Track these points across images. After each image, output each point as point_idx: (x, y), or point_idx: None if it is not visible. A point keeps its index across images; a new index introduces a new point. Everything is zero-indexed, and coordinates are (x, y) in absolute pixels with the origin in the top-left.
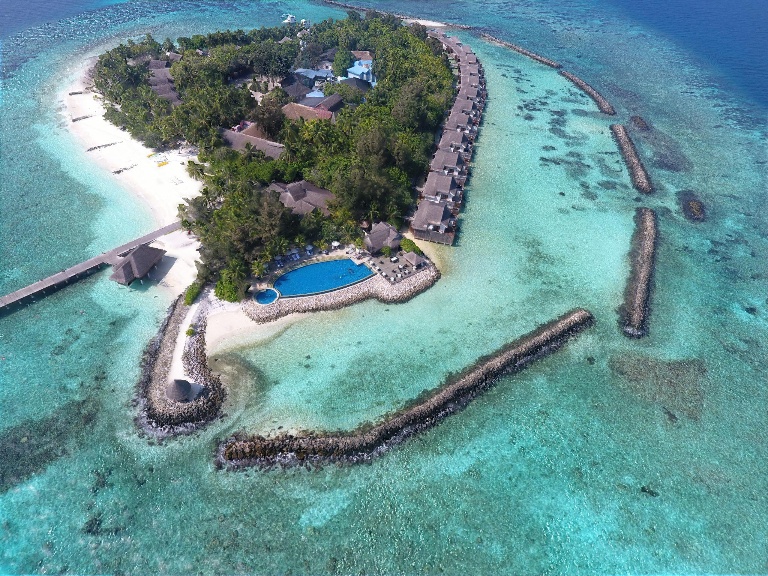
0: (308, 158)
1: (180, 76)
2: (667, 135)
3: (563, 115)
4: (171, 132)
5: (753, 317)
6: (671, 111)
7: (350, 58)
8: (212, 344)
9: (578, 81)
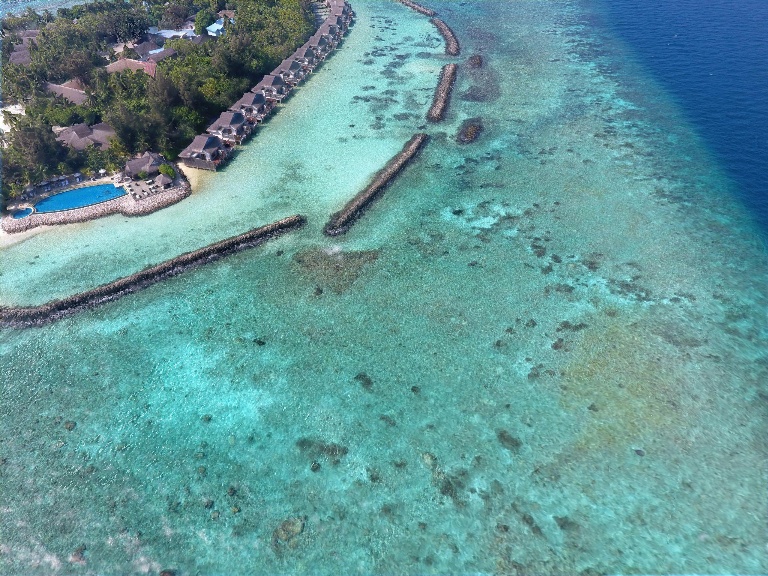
0: (109, 103)
1: (30, 40)
2: (496, 71)
3: (405, 58)
4: (1, 88)
5: (455, 217)
6: (518, 49)
7: (211, 17)
8: None
9: (442, 27)
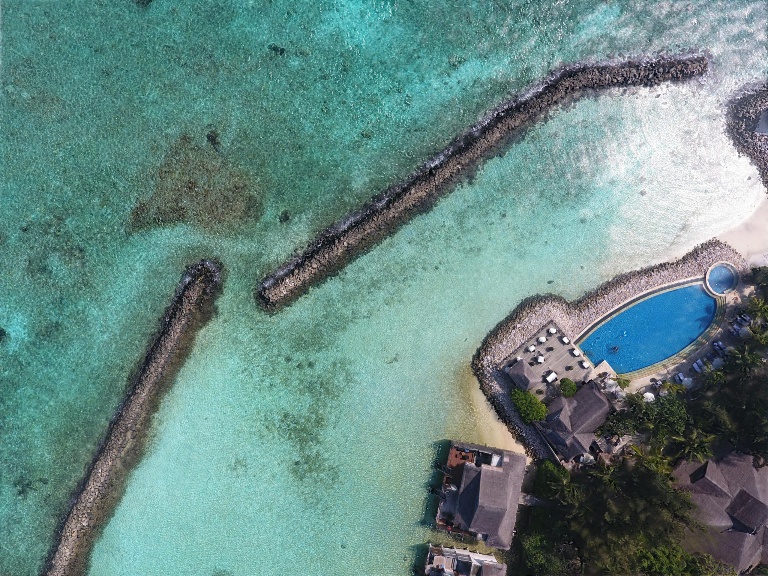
0: None
1: None
2: None
3: None
4: None
5: (1, 322)
6: None
7: None
8: (762, 201)
9: None
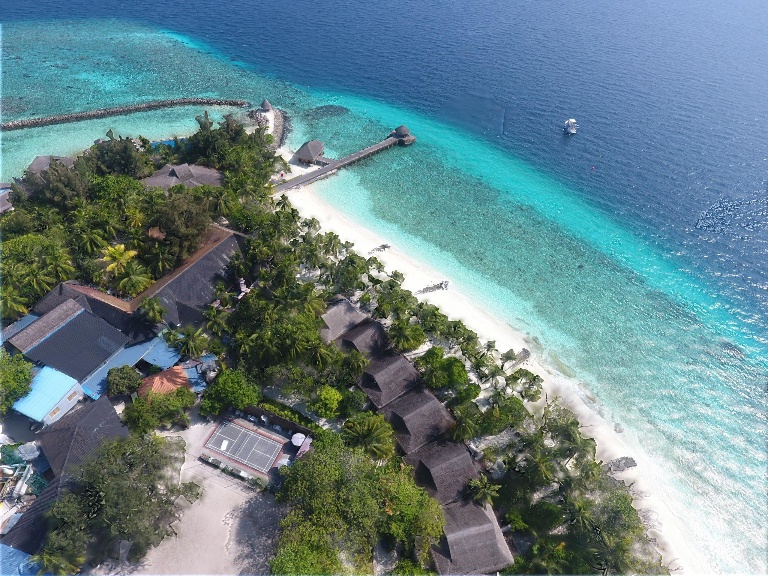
0: None
1: None
2: None
3: None
4: None
5: None
6: None
7: None
8: None
9: None
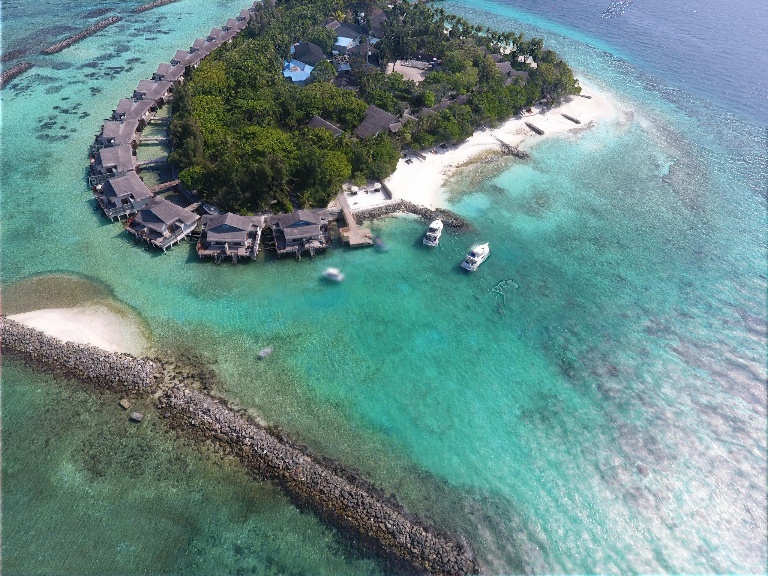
0: None
1: None
2: (8, 47)
3: None
4: None
5: None
6: None
7: None
8: None
9: None
